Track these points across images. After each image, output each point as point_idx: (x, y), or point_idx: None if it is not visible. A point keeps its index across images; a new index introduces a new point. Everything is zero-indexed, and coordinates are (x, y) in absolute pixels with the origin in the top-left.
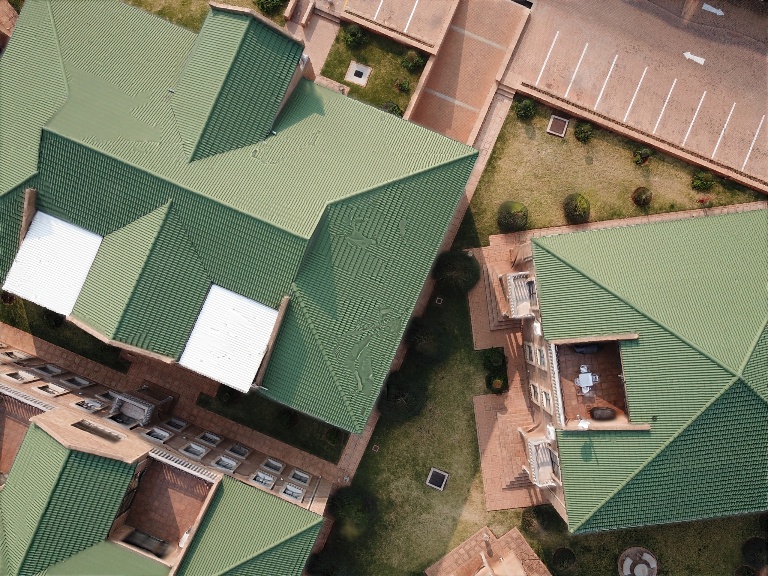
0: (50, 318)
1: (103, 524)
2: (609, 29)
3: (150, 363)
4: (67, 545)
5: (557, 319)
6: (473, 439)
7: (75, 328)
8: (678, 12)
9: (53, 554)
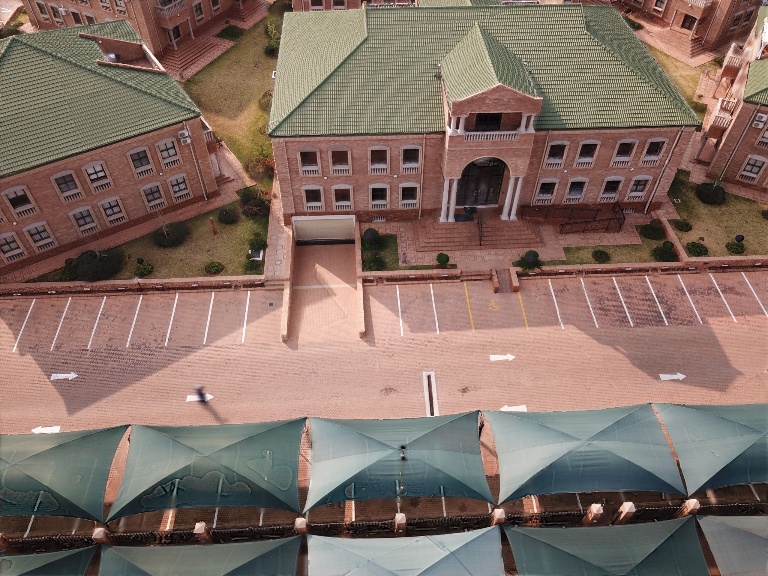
0: None
1: (498, 1)
2: None
3: None
4: (486, 2)
5: None
6: (650, 47)
7: None
8: None
9: (482, 3)
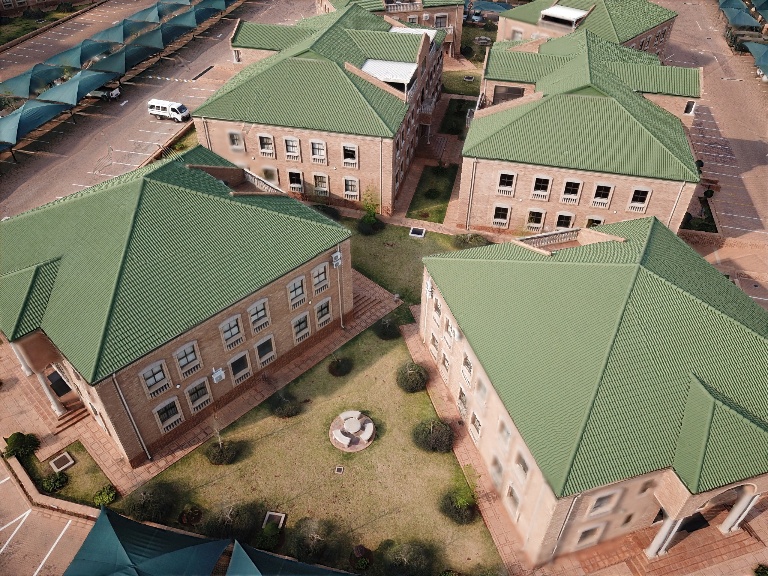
0: (432, 190)
1: None
2: (227, 52)
3: (447, 157)
4: None
5: (375, 5)
6: None
7: (436, 186)
8: (220, 41)
9: None
